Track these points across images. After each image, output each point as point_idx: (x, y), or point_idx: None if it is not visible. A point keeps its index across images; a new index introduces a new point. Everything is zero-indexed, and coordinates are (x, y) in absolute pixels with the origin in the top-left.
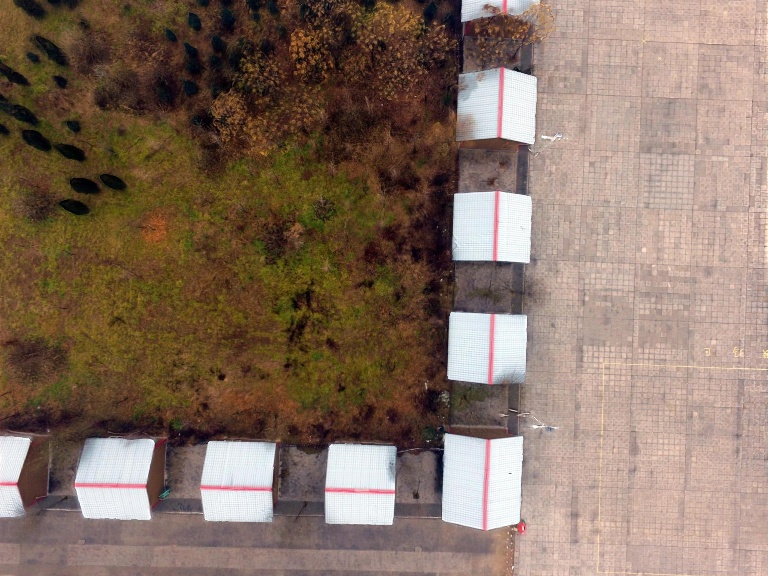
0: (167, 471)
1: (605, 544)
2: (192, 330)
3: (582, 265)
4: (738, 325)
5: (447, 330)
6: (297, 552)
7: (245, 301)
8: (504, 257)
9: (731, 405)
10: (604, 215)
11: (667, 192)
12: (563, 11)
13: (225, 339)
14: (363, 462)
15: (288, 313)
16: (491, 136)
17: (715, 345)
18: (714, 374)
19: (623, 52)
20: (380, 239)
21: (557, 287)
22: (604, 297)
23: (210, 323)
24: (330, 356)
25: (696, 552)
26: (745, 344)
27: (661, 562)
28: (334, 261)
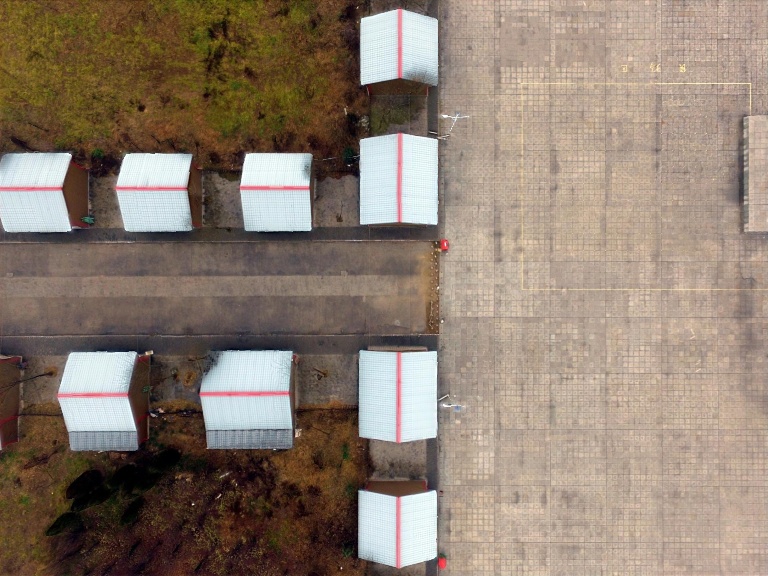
0: (91, 202)
1: (529, 262)
2: (110, 61)
3: None
4: (654, 41)
5: (359, 38)
6: (224, 279)
7: (162, 32)
8: None
9: (649, 120)
10: None
11: None
12: None
13: (143, 71)
14: (279, 166)
15: (205, 43)
16: None
17: (632, 61)
18: (632, 90)
19: None
20: None
21: (473, 10)
22: (520, 18)
23: (128, 55)
24: (249, 85)
25: (619, 266)
26: (662, 59)
27: (585, 277)
28: None
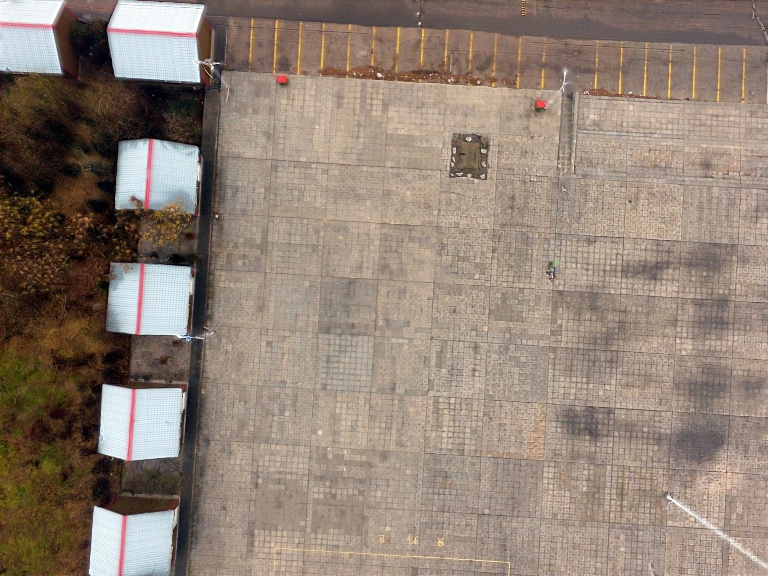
0: None
1: None
2: None
3: (256, 447)
4: (413, 512)
5: (92, 523)
6: None
7: None
8: (141, 455)
9: None
10: (280, 396)
11: (345, 374)
12: (243, 187)
13: None
14: None
15: None
16: (131, 331)
17: (389, 532)
18: (387, 562)
19: (304, 230)
20: (49, 417)
21: (230, 469)
22: (278, 480)
23: None
24: None
25: None
26: (420, 531)
27: None
28: (0, 439)
